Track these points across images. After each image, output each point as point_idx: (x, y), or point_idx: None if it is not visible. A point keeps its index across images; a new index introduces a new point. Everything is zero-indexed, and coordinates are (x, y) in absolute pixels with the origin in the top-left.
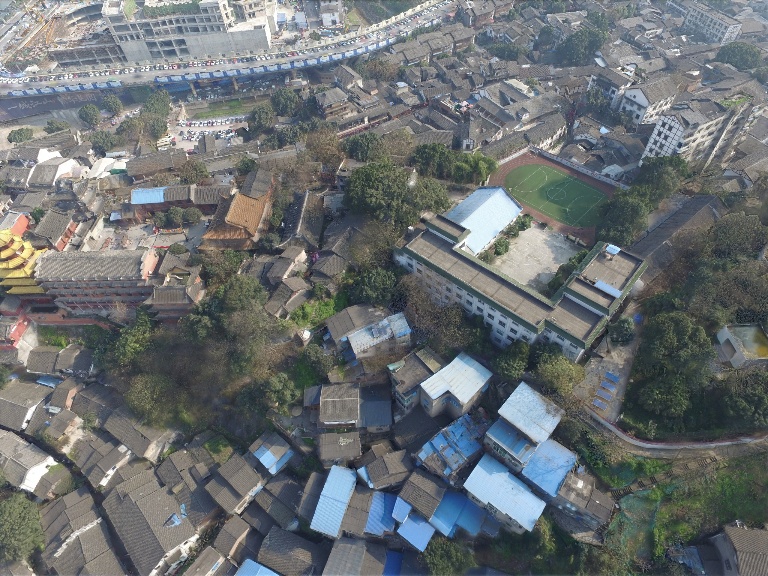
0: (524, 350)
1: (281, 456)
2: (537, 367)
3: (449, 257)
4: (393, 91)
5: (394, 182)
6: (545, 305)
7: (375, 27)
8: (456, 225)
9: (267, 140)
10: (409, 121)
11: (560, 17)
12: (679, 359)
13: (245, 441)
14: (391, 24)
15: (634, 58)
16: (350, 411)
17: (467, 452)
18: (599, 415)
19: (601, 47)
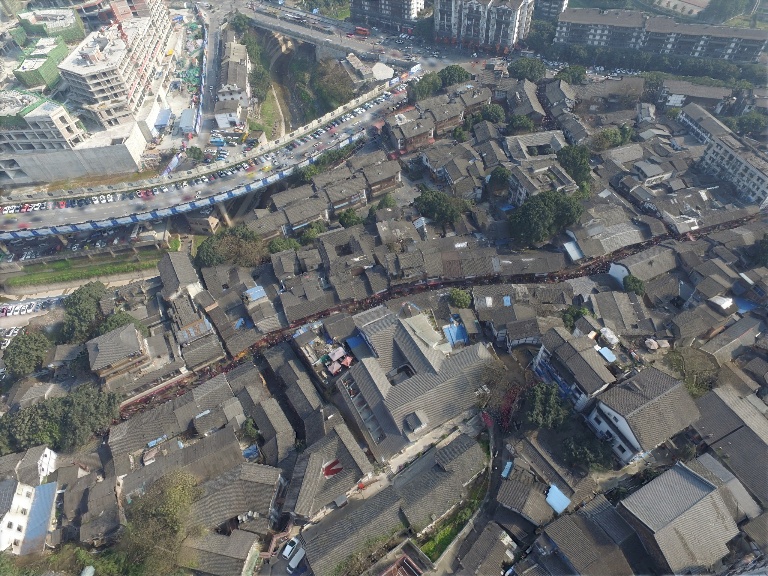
0: None
1: None
2: None
3: None
4: (243, 302)
5: None
6: None
7: (273, 144)
8: None
9: None
10: None
11: (525, 141)
12: None
13: None
14: (296, 139)
15: (627, 234)
16: None
17: None
18: None
19: (576, 220)
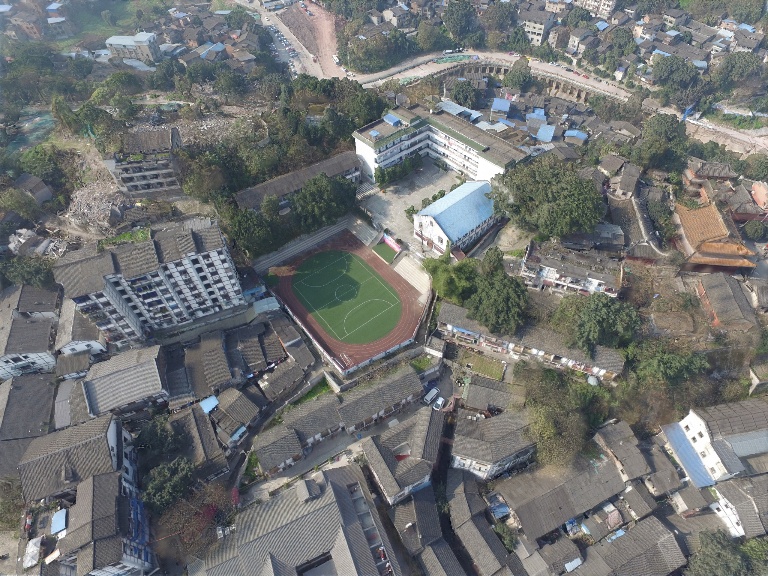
0: None
1: None
2: None
3: None
4: None
5: None
6: None
7: None
8: None
9: None
10: None
11: None
12: None
13: None
14: None
15: None
16: None
17: None
18: None
19: None
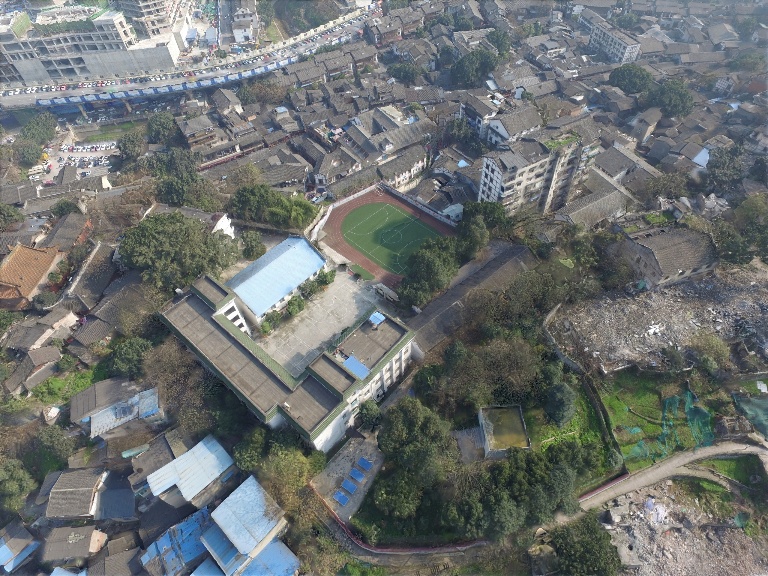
0: (254, 439)
1: (21, 549)
2: (269, 458)
3: (207, 326)
4: (273, 116)
5: (170, 237)
6: (285, 386)
7: (281, 44)
8: (221, 289)
9: (124, 172)
10: (278, 150)
11: (467, 35)
12: (403, 455)
13: (2, 526)
14: (299, 41)
15: (530, 79)
16: (82, 504)
17: (188, 556)
18: (332, 513)
19: (495, 68)
